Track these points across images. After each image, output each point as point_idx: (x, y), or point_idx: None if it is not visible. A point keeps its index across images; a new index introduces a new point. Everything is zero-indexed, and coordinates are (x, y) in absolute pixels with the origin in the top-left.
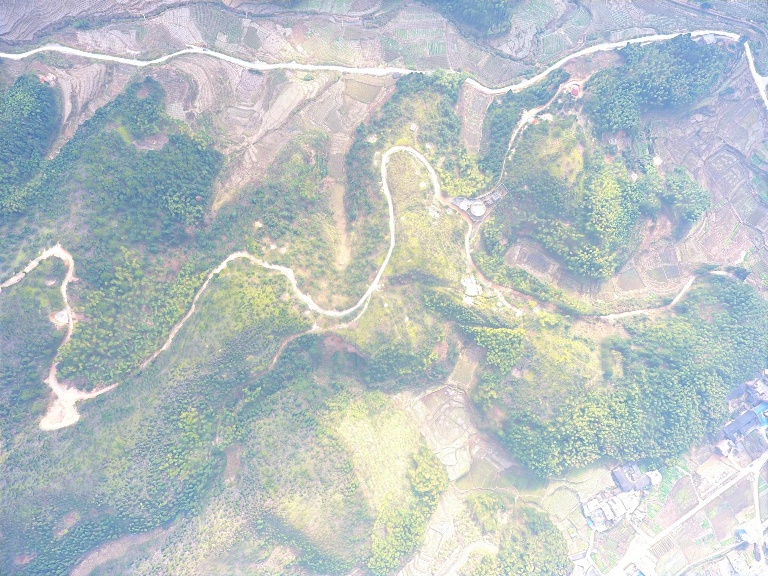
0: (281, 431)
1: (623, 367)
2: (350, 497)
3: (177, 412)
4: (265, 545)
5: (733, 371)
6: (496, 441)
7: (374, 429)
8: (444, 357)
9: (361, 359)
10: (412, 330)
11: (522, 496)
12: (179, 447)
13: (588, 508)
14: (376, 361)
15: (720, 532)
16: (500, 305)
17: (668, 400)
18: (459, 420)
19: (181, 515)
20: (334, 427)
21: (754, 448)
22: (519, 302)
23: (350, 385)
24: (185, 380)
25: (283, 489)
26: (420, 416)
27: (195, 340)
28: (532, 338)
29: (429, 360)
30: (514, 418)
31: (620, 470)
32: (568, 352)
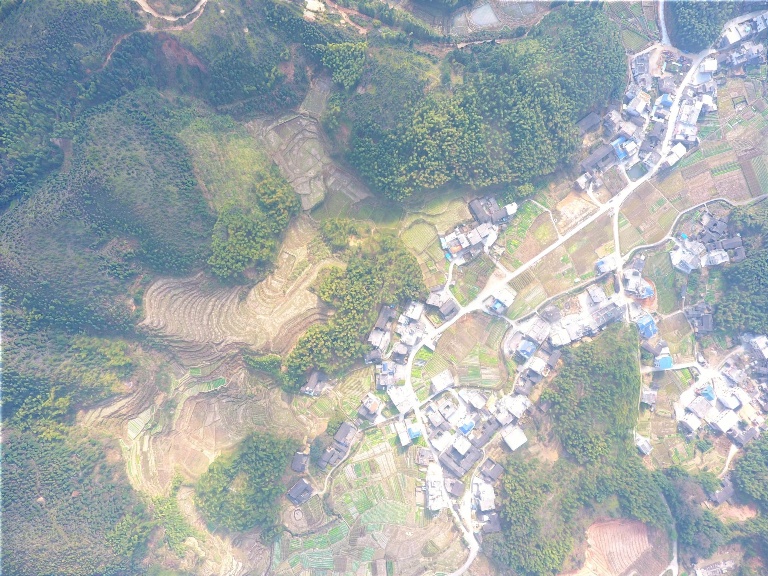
0: (113, 121)
1: (463, 76)
2: (186, 191)
3: (4, 92)
4: (99, 230)
5: (580, 88)
6: (349, 170)
7: (218, 142)
8: (291, 79)
9: (206, 77)
10: (252, 41)
11: (379, 228)
12: (6, 126)
13: (445, 240)
14: (215, 69)
15: (580, 266)
16: (343, 22)
17: (511, 111)
18: (313, 151)
19: (16, 201)
20: (174, 132)
21: (613, 183)
22: (363, 20)
23: (197, 105)
24: (10, 60)
25: (108, 164)
26: (273, 145)
27: (20, 22)
28: (375, 53)
29: (272, 74)
30: (356, 128)
31: (476, 201)
32: (409, 62)
